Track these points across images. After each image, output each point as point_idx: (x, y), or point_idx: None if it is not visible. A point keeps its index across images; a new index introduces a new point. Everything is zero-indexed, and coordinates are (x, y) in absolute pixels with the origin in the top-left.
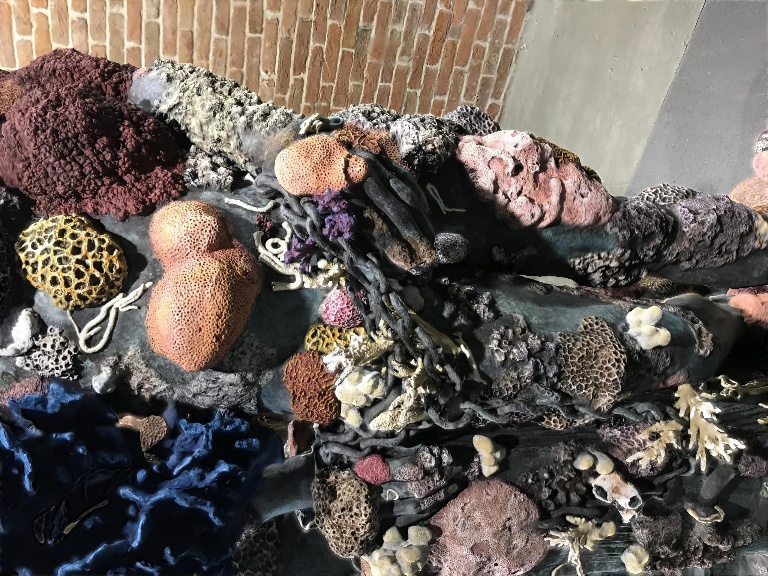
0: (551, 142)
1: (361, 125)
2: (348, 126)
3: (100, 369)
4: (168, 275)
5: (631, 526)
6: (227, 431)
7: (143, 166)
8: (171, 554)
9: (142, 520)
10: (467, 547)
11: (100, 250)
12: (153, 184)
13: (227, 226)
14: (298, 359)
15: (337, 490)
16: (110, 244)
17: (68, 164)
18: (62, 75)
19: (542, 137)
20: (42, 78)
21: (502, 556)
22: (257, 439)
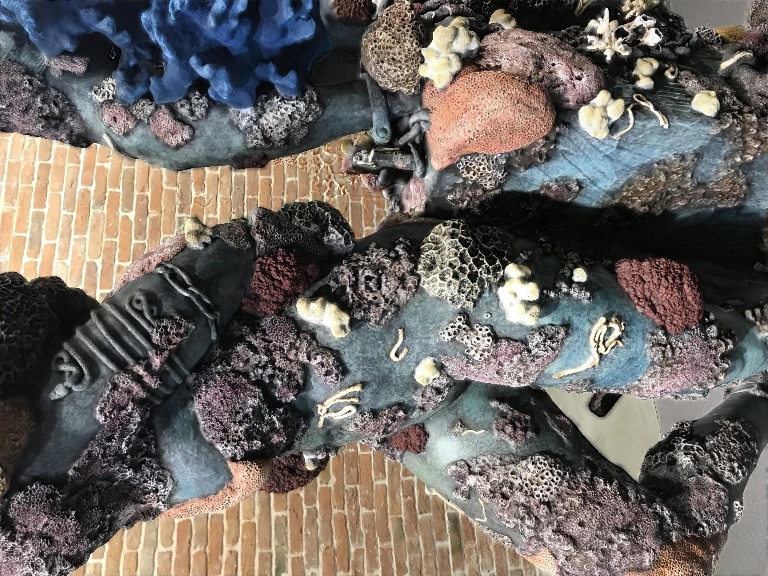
0: (574, 408)
1: None
2: None
3: None
4: None
5: (680, 83)
6: None
7: None
8: None
9: None
10: (515, 43)
11: None
12: None
13: None
14: None
15: None
16: None
17: None
18: None
19: (565, 413)
20: None
21: (554, 56)
22: None
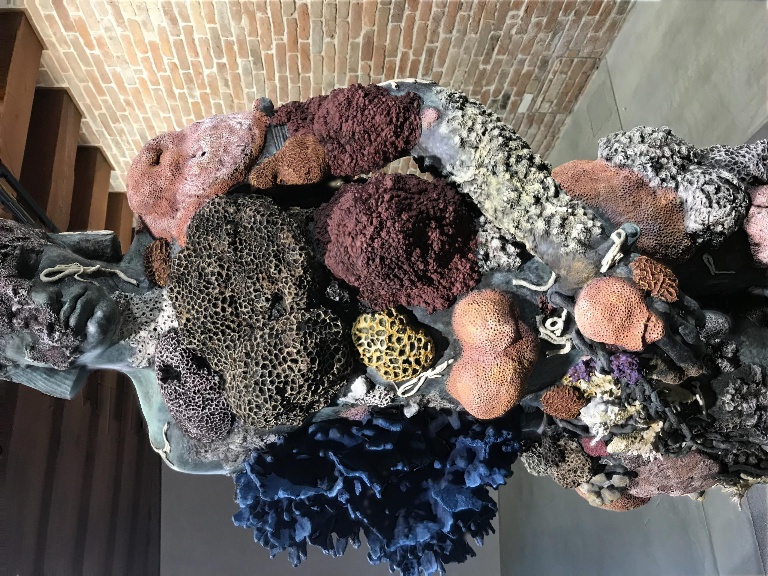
0: None
1: (648, 179)
2: (634, 181)
3: (409, 402)
4: (466, 356)
5: None
6: (498, 442)
7: (446, 259)
8: (463, 526)
9: (451, 522)
10: (655, 487)
11: (419, 349)
12: (455, 278)
13: (514, 310)
14: (556, 393)
15: (566, 457)
16: (425, 342)
17: (392, 281)
18: (361, 138)
19: None
20: (342, 139)
21: (680, 490)
22: (517, 443)
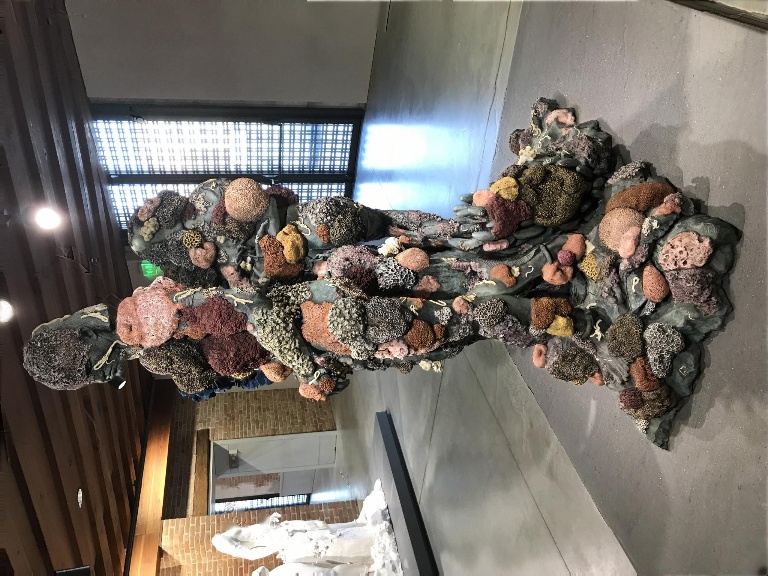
0: None
1: None
2: None
3: None
4: None
5: None
6: None
7: None
8: None
9: None
10: None
11: None
12: None
13: None
14: None
15: None
16: None
17: None
18: None
19: None
20: None
21: None
22: None
